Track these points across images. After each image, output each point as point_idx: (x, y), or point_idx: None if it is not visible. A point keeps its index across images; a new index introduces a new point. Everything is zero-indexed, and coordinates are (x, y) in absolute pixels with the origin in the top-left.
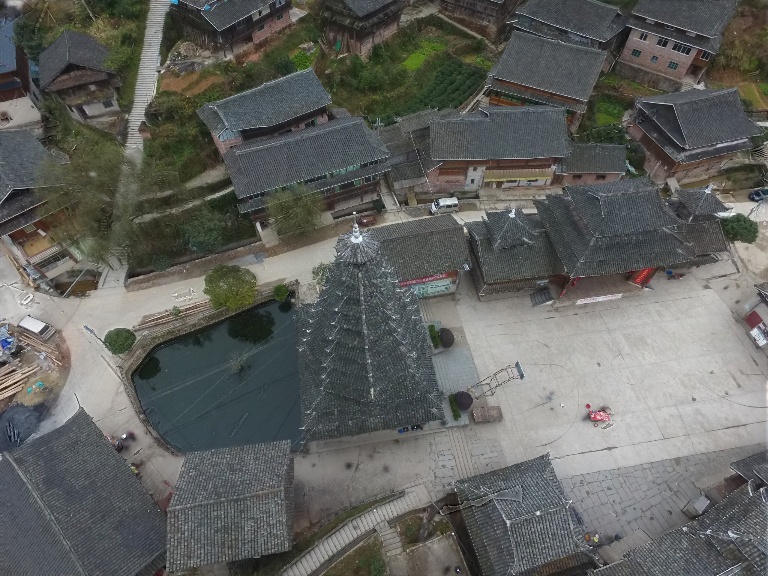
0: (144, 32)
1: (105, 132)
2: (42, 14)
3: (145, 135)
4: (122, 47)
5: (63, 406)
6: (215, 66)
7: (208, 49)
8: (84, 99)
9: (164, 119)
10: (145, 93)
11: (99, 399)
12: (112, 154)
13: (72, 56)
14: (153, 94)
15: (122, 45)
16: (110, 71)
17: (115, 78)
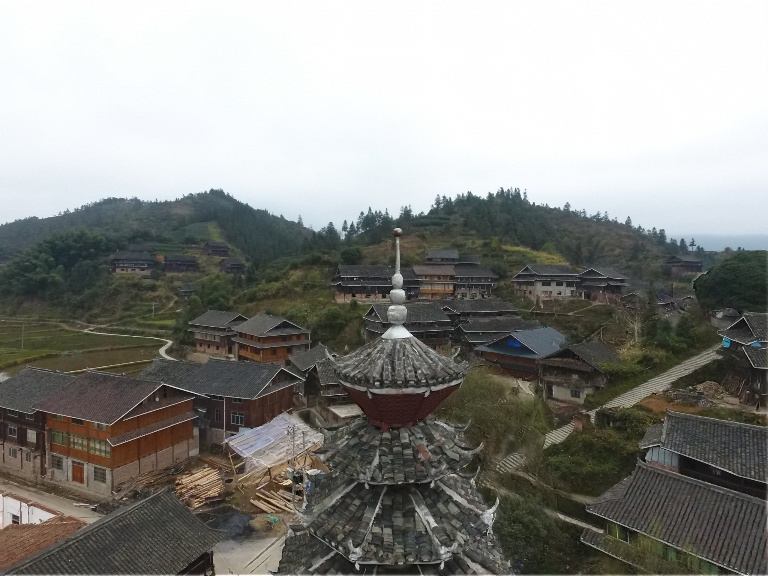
0: (674, 366)
1: (550, 409)
2: (595, 333)
3: (577, 424)
4: (635, 365)
5: (252, 546)
6: (733, 413)
7: (739, 397)
8: (558, 380)
9: (615, 427)
10: (622, 404)
11: (262, 569)
12: (499, 382)
13: (577, 347)
14: (629, 407)
15: (637, 363)
16: (599, 368)
17: (600, 377)
